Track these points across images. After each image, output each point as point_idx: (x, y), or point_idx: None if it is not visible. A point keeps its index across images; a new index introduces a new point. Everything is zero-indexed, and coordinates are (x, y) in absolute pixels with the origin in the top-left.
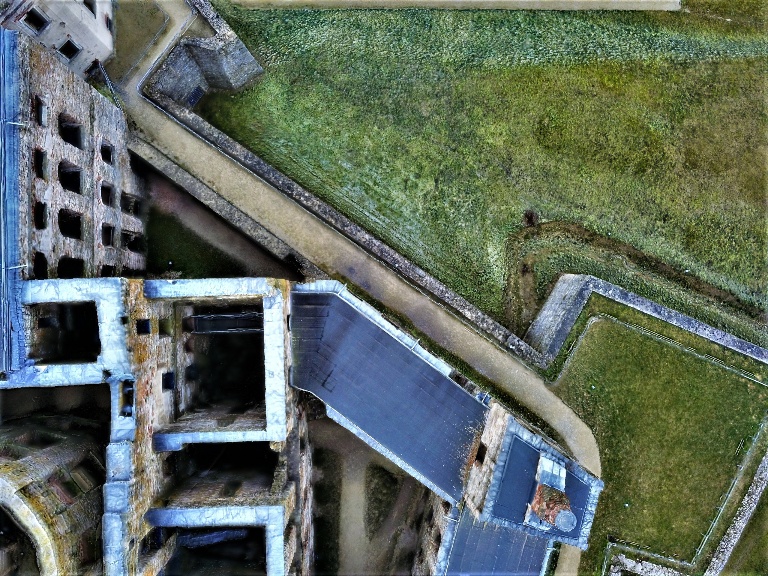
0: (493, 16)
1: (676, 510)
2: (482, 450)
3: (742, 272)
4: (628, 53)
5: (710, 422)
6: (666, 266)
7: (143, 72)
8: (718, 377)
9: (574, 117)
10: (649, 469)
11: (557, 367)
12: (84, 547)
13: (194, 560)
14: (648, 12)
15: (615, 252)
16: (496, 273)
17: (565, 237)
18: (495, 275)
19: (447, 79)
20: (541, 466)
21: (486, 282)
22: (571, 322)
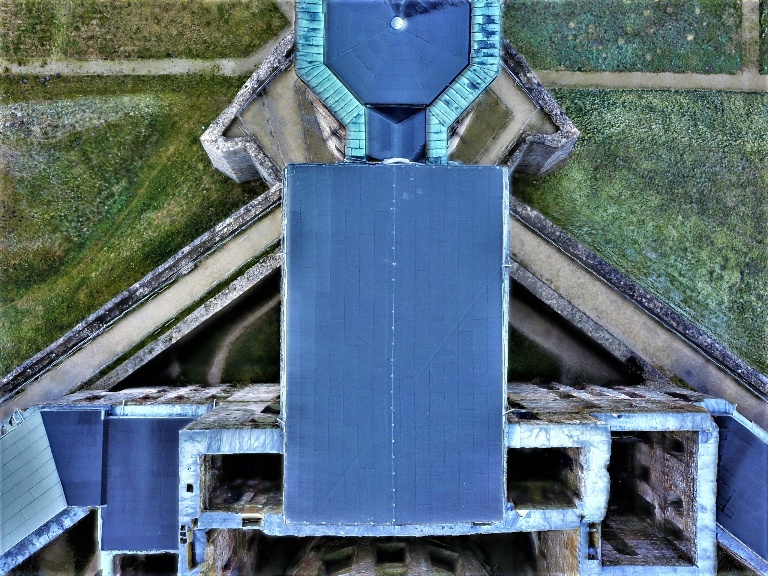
0: None
1: None
2: None
3: None
4: None
5: None
6: None
7: None
8: None
9: None
10: None
11: None
12: None
13: None
14: None
15: None
16: None
17: None
18: None
19: (752, 169)
20: None
21: None
22: None
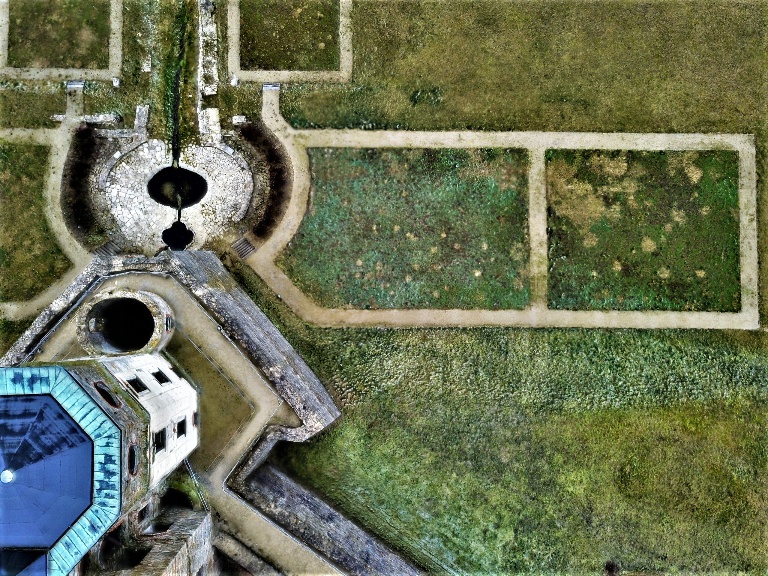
0: (569, 337)
1: None
2: None
3: None
4: (709, 389)
5: None
6: None
7: (227, 461)
8: None
9: (656, 466)
10: None
11: None
12: None
13: None
14: (726, 331)
15: None
16: None
17: None
18: None
19: (526, 423)
20: None
21: None
22: None
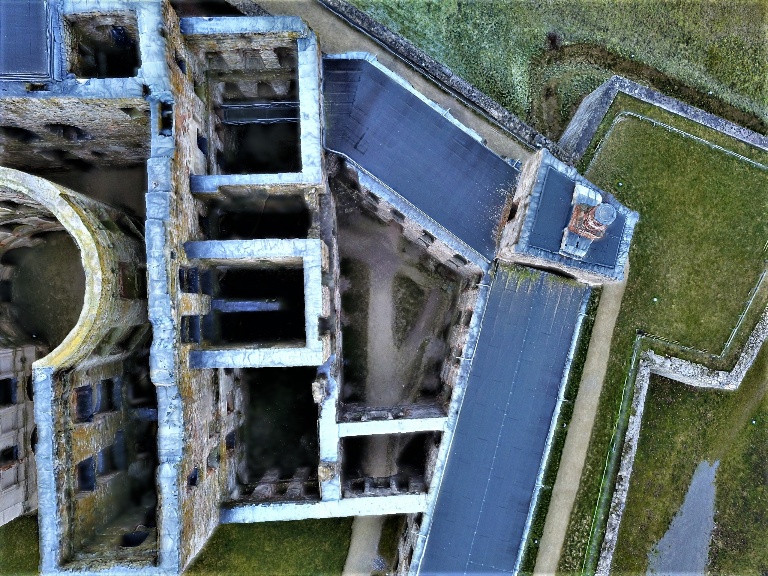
0: None
1: (705, 305)
2: (514, 210)
3: (766, 94)
4: None
5: (738, 218)
6: (689, 89)
7: None
8: (745, 175)
9: None
10: (677, 264)
11: (584, 166)
12: (124, 283)
13: (228, 336)
14: None
15: (638, 77)
16: (520, 94)
17: (588, 63)
18: (519, 96)
19: None
20: (577, 190)
21: (510, 103)
22: (598, 121)
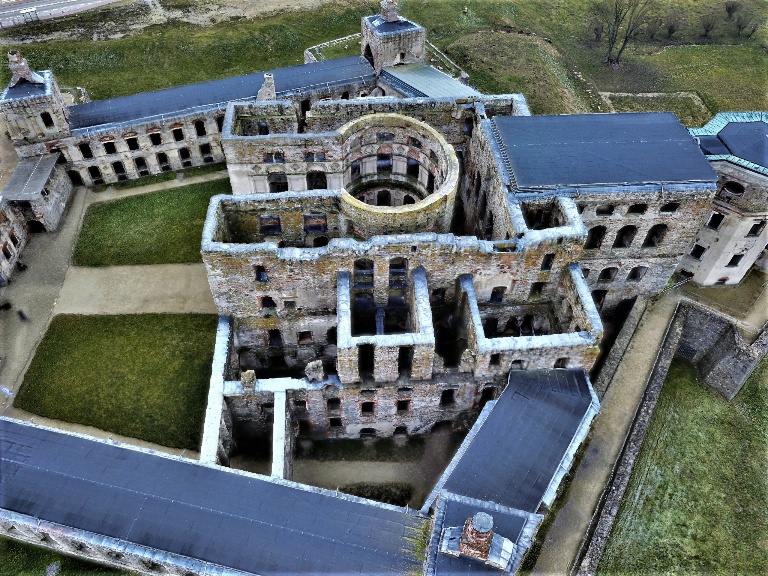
0: None
1: None
2: None
3: None
4: None
5: None
6: None
7: None
8: None
9: None
10: None
11: None
12: None
13: (357, 328)
14: None
15: None
16: None
17: None
18: None
19: None
20: None
21: None
22: None
